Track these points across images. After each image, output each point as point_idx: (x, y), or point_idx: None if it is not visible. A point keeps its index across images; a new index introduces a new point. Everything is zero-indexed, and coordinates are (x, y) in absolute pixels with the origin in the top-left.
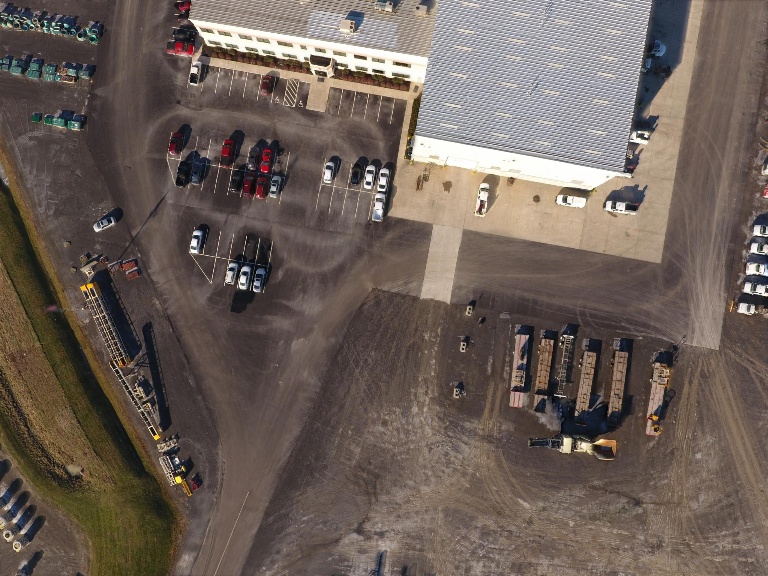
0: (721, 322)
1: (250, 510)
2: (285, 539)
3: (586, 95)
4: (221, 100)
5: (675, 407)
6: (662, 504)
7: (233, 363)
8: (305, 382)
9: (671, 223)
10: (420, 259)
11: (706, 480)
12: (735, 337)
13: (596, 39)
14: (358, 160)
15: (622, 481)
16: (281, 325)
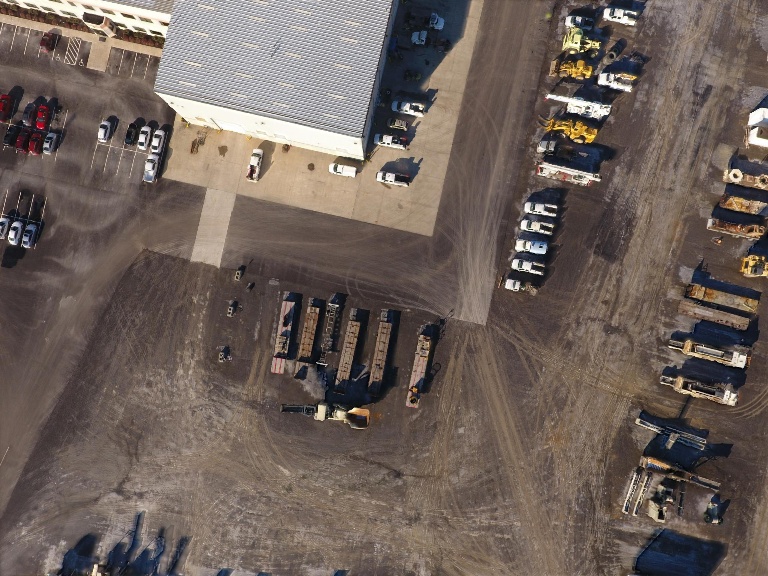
0: (490, 298)
1: (9, 465)
2: (43, 495)
3: (328, 59)
4: (2, 55)
5: (440, 381)
6: (422, 477)
7: (1, 318)
8: (71, 340)
9: (445, 197)
10: (192, 222)
11: (467, 455)
12: (503, 313)
13: (341, 4)
14: (135, 121)
15: (383, 452)
16: (50, 282)
